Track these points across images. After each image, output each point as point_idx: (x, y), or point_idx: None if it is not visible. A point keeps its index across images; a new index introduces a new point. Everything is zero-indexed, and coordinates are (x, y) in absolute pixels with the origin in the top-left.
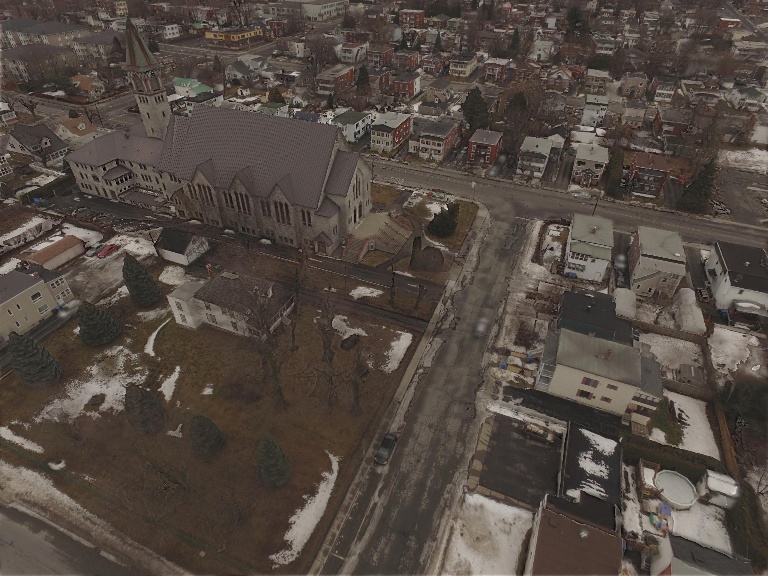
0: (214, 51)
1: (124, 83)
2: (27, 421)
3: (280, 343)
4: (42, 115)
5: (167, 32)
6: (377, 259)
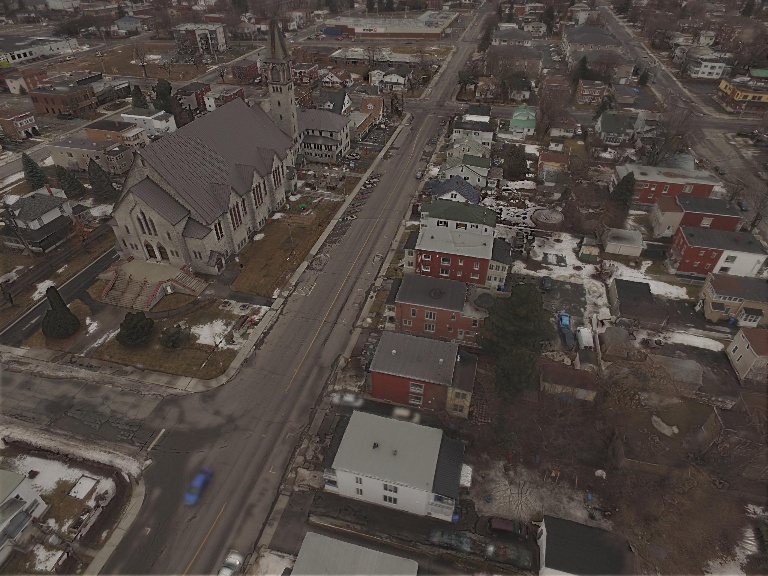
0: (698, 104)
1: (510, 96)
2: (8, 193)
3: (1, 254)
4: (422, 96)
5: (701, 69)
6: (97, 289)
